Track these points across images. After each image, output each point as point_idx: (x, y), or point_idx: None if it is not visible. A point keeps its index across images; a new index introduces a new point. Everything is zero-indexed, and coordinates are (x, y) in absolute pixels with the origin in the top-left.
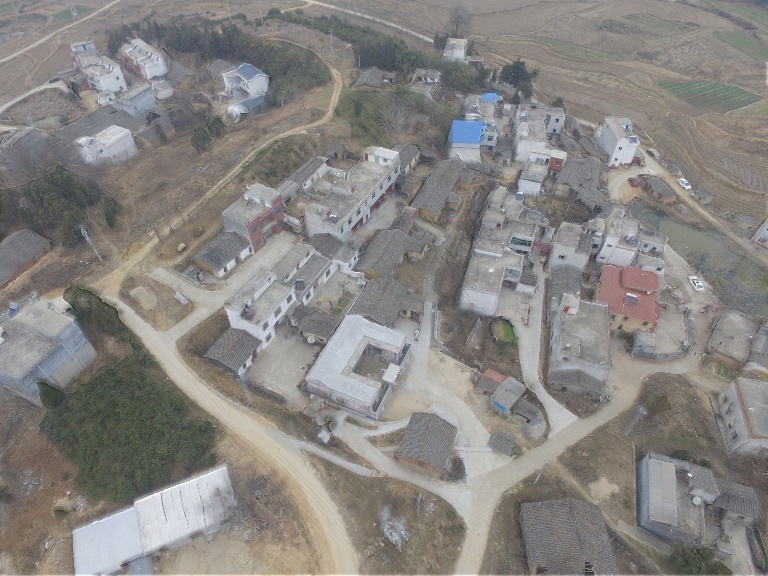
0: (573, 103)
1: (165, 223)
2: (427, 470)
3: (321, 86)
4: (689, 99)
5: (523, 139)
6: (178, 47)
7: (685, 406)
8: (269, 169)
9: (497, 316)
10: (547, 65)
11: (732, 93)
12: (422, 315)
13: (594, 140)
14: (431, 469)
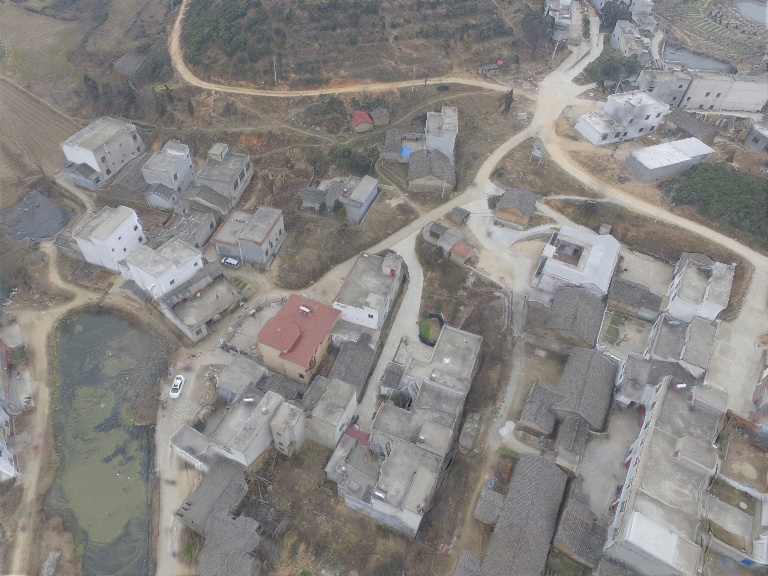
0: None
1: None
2: None
3: None
4: None
5: None
6: None
7: None
8: None
9: None
10: None
11: None
12: None
13: None
14: None
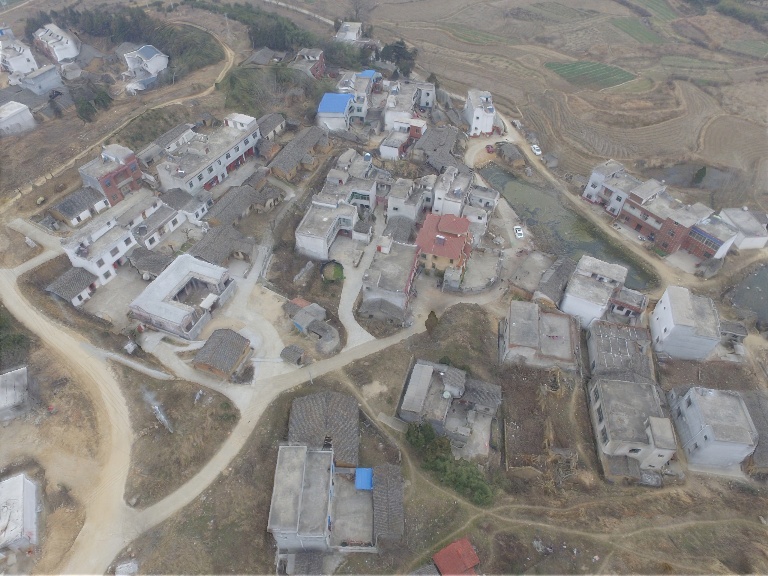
0: (444, 79)
1: (33, 182)
2: (217, 374)
3: (213, 65)
4: (570, 78)
5: (389, 110)
6: (90, 31)
7: (469, 327)
8: (135, 134)
9: (331, 260)
10: (446, 48)
11: (611, 73)
12: (251, 255)
13: (461, 112)
14: (217, 372)
